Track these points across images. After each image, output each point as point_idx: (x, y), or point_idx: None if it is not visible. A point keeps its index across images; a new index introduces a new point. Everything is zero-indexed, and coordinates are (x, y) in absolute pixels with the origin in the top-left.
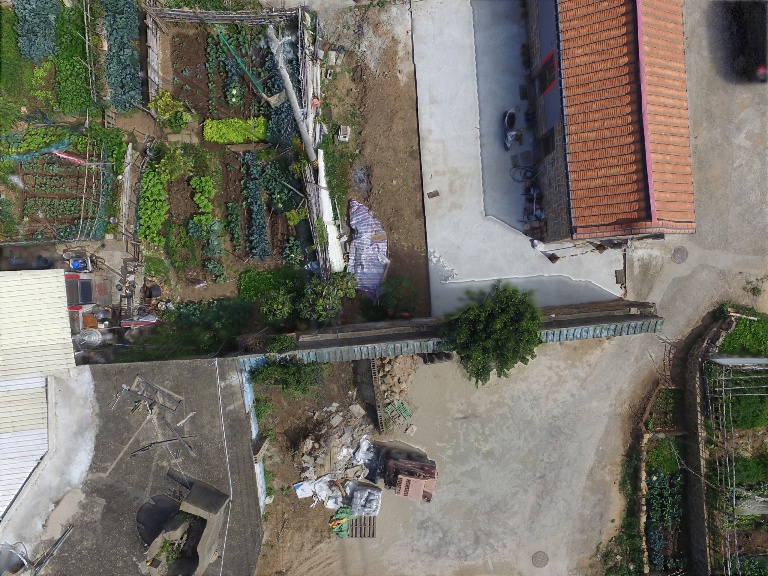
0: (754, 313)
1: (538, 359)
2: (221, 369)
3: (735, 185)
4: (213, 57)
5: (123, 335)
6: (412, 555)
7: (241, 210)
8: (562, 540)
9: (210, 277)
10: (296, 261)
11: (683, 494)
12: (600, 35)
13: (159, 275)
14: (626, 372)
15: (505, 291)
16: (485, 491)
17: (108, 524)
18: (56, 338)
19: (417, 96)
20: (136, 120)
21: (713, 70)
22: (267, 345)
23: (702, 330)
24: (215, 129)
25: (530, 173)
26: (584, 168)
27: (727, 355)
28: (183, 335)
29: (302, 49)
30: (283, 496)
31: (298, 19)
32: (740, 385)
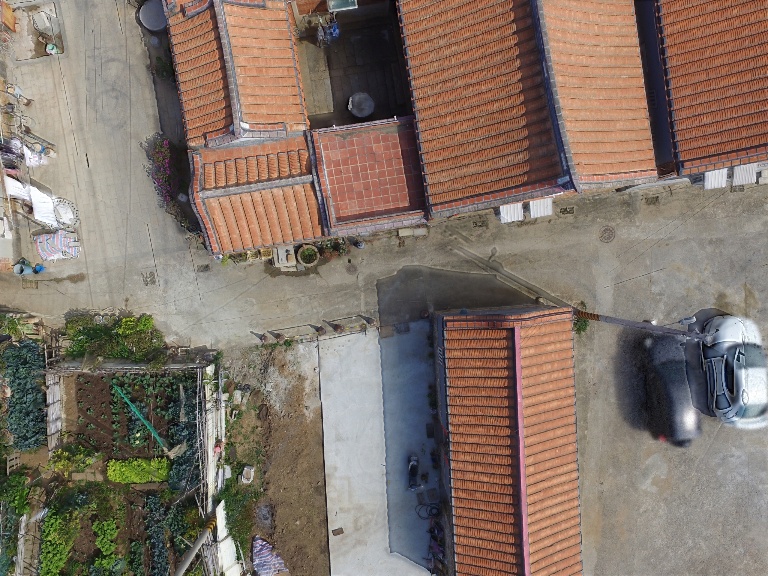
0: None
1: None
2: None
3: (641, 530)
4: (118, 398)
5: None
6: None
7: (145, 546)
8: None
9: None
10: None
11: None
12: (487, 449)
13: None
14: None
15: None
16: None
17: None
18: None
19: (323, 434)
20: (41, 456)
21: (621, 416)
22: None
23: None
24: (118, 473)
25: (436, 510)
26: (471, 572)
27: None
28: None
29: (201, 410)
30: None
31: (197, 384)
32: None
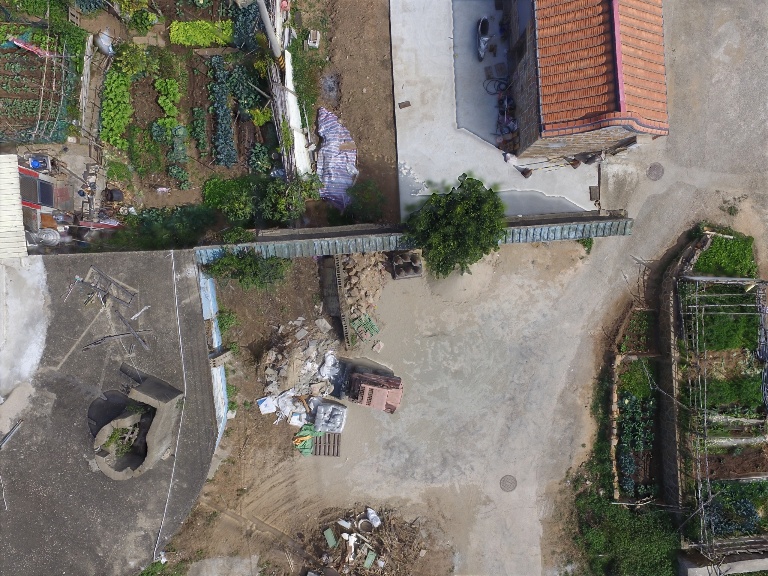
0: (730, 232)
1: (509, 277)
2: (177, 261)
3: (713, 100)
4: None
5: (83, 238)
6: (377, 476)
7: (207, 116)
8: (531, 464)
9: (174, 184)
10: (263, 169)
11: (656, 420)
12: None
13: (122, 180)
14: (599, 293)
15: (468, 179)
16: (453, 412)
17: (58, 419)
18: (8, 225)
19: (390, 4)
20: (102, 22)
21: None
22: (224, 235)
23: (677, 250)
24: (182, 31)
25: (504, 85)
26: (554, 63)
27: (702, 274)
28: (144, 239)
29: None
30: (246, 411)
31: None
32: (714, 304)
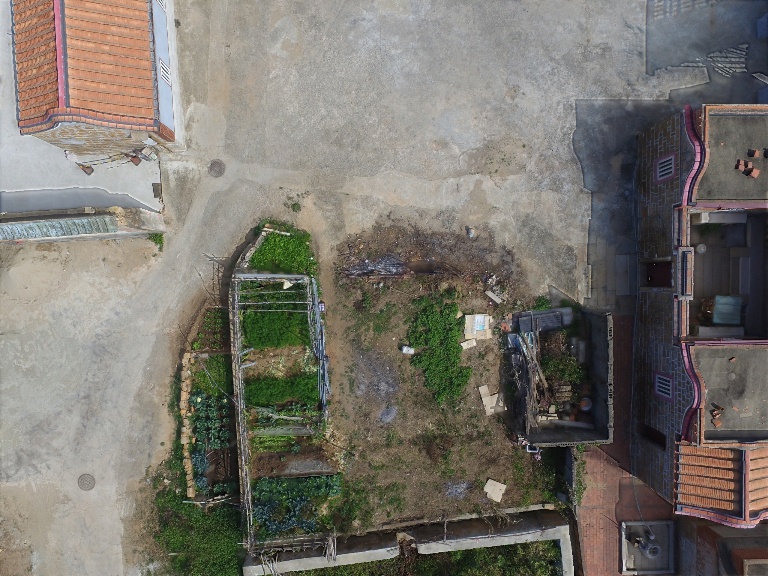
0: (288, 228)
1: (80, 275)
2: None
3: (271, 96)
4: None
5: None
6: None
7: None
8: (109, 463)
9: None
10: None
11: None
12: None
13: None
14: (174, 290)
15: None
16: (26, 410)
17: None
18: None
19: None
20: None
21: None
22: None
23: (244, 247)
24: None
25: None
26: (27, 59)
27: (258, 271)
28: None
29: None
30: None
31: None
32: (266, 301)
